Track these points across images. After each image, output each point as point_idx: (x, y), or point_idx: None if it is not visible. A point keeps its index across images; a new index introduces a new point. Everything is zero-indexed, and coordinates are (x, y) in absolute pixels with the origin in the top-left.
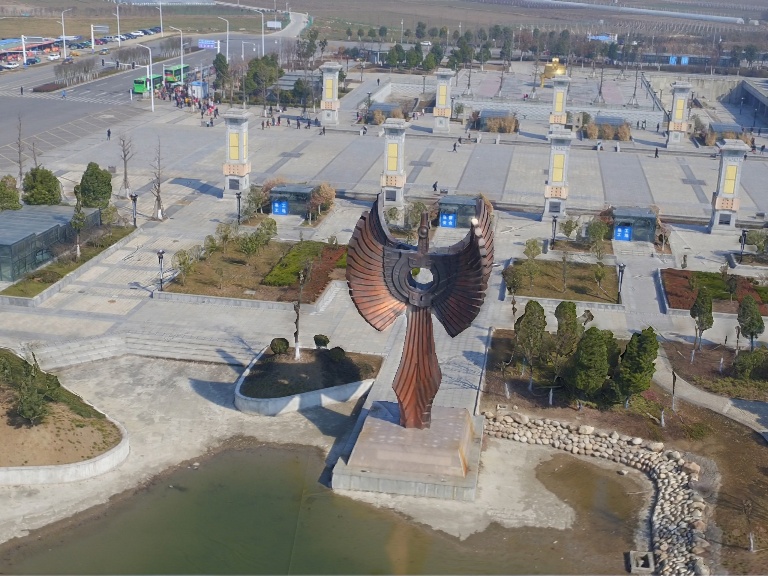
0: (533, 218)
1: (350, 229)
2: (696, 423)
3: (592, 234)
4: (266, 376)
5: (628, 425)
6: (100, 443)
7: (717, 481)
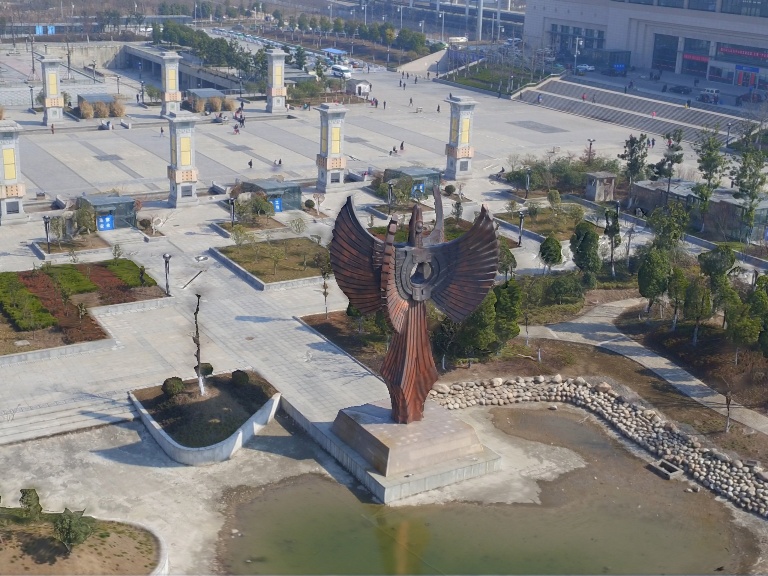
0: (163, 206)
1: (6, 252)
2: (559, 352)
3: (252, 211)
4: (190, 421)
5: (517, 368)
6: (140, 546)
7: (630, 391)
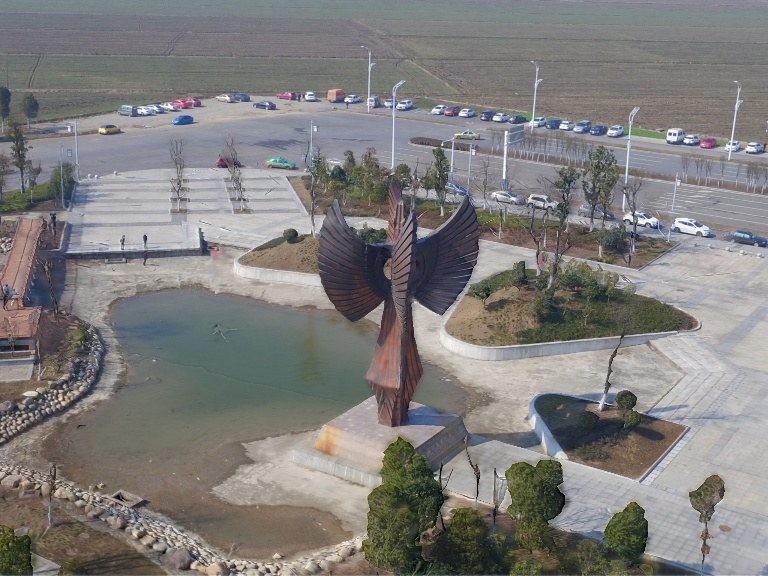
0: None
1: None
2: None
3: None
4: None
5: (352, 575)
6: None
7: None
